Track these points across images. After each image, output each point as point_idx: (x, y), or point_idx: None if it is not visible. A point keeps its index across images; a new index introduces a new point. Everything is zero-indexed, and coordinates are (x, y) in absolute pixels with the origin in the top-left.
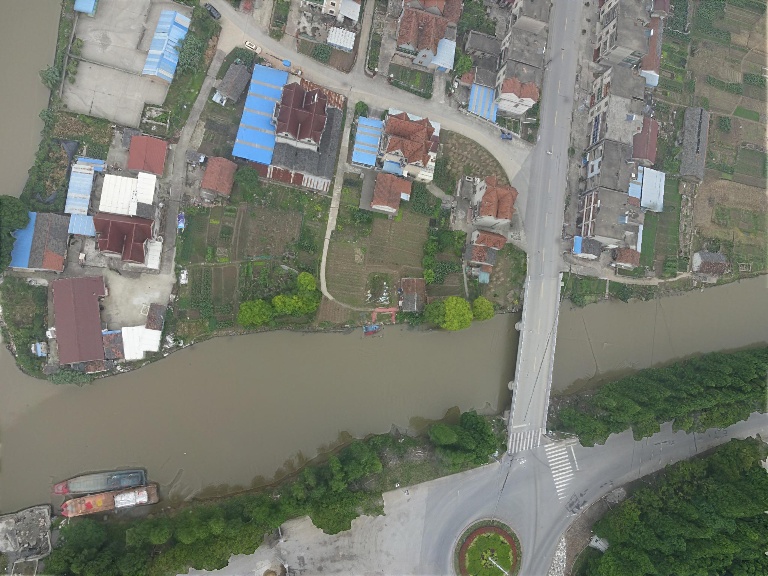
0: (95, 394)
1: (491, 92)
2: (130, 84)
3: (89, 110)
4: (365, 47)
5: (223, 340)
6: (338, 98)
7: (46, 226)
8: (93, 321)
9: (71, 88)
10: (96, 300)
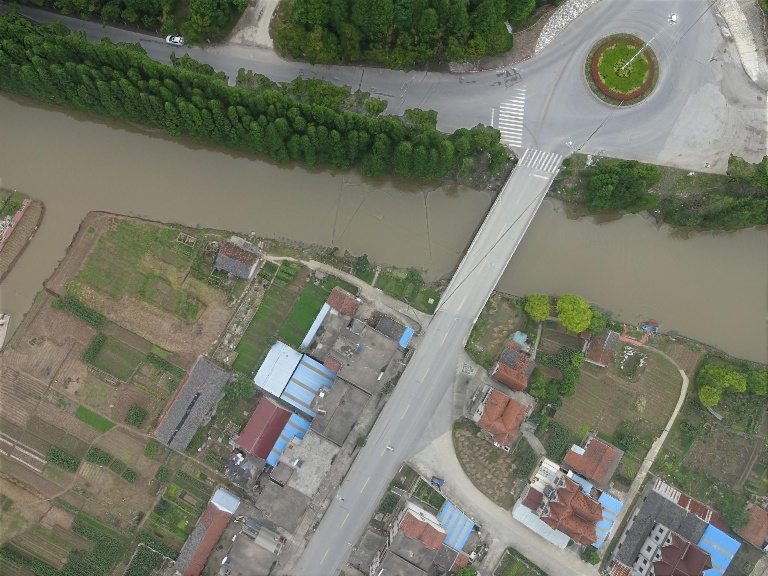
0: None
1: None
2: None
3: None
4: None
5: None
6: (616, 575)
7: None
8: None
9: None
10: None
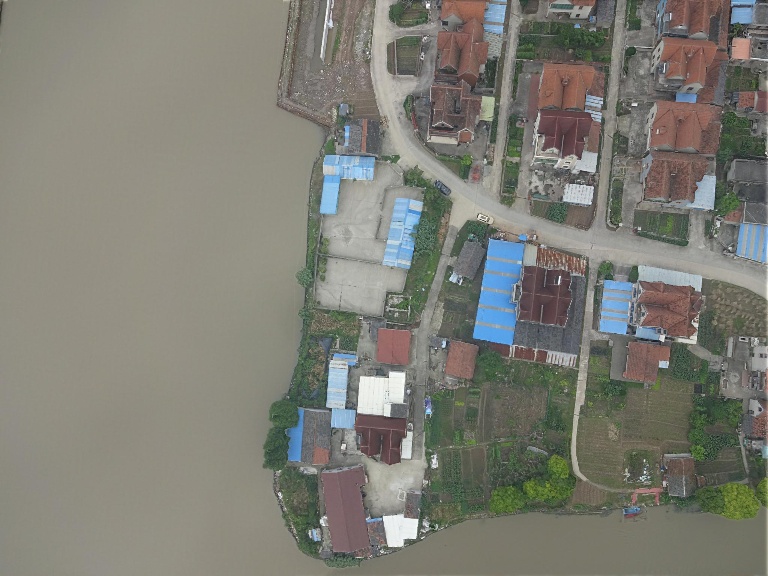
0: (363, 573)
1: (766, 229)
2: (372, 274)
3: (339, 304)
4: (605, 197)
5: (475, 523)
6: (579, 263)
7: (313, 424)
8: (358, 511)
9: (322, 285)
10: (359, 490)
